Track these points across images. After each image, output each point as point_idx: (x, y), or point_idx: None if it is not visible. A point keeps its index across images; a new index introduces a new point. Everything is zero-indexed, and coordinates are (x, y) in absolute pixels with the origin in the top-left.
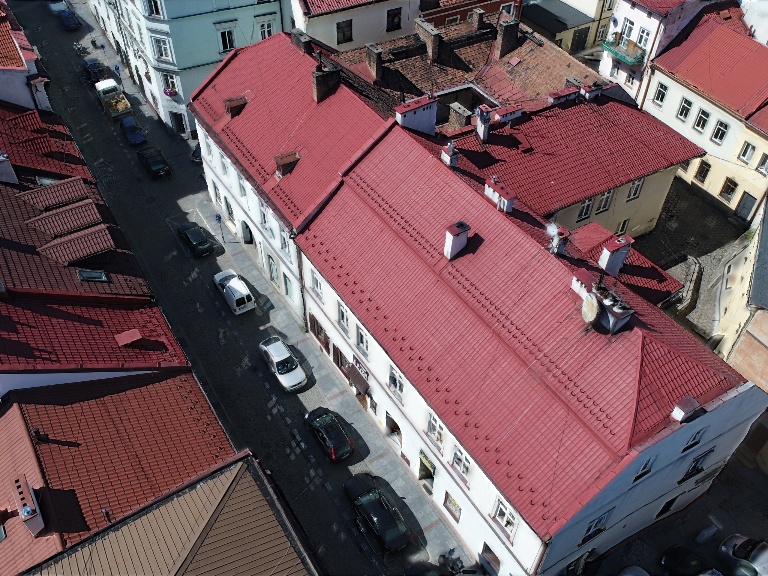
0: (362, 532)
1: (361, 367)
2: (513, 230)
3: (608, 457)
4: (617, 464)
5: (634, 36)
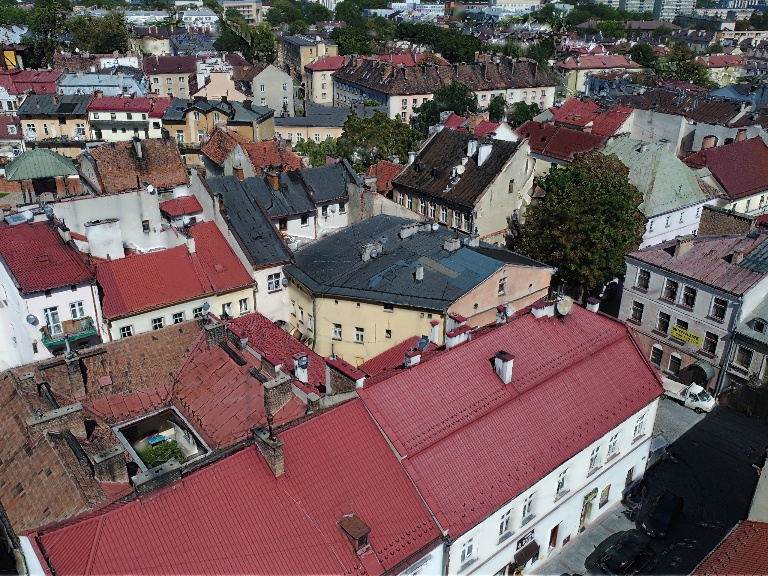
0: (639, 571)
1: (528, 537)
2: (491, 336)
3: (625, 341)
4: (629, 338)
5: (67, 316)
